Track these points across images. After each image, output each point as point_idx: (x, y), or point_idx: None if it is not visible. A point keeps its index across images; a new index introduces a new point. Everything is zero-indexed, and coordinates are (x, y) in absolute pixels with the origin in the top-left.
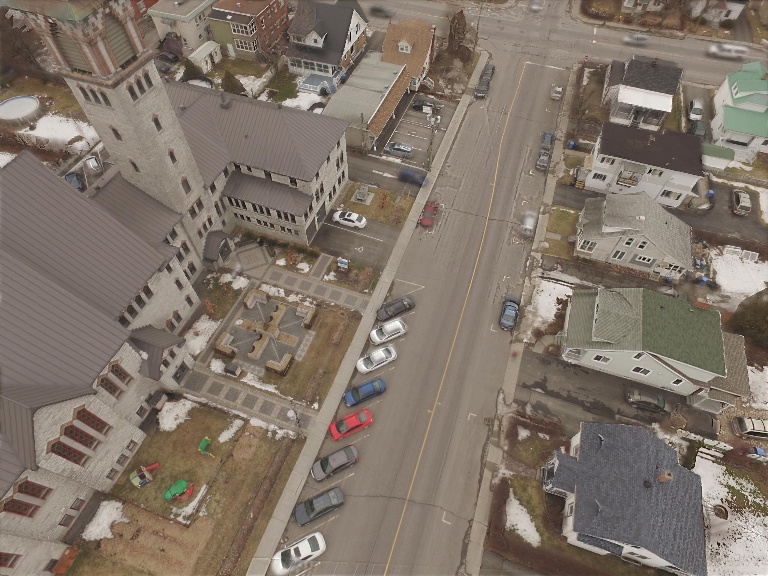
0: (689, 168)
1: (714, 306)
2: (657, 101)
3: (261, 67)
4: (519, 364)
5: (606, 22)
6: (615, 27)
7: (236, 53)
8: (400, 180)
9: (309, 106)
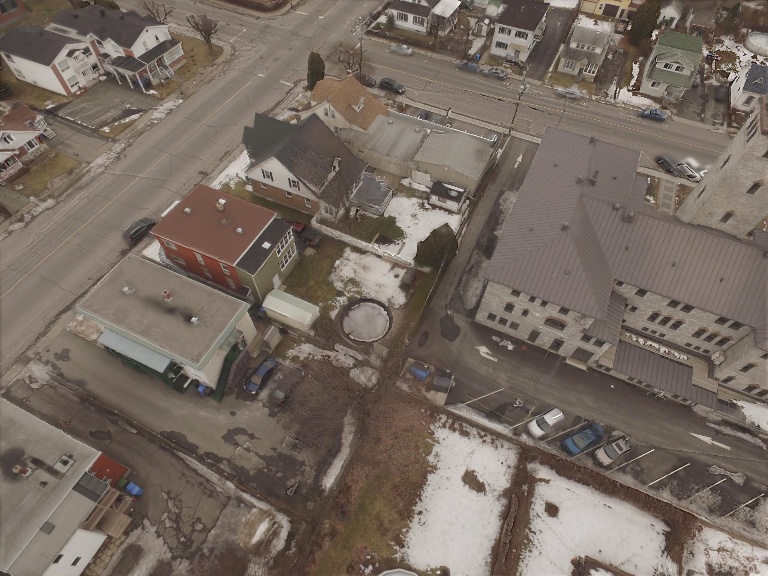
0: (543, 6)
1: (618, 45)
2: (449, 3)
3: (314, 254)
4: (688, 120)
5: (291, 4)
6: (298, 3)
7: (281, 278)
8: (525, 152)
9: (412, 207)
